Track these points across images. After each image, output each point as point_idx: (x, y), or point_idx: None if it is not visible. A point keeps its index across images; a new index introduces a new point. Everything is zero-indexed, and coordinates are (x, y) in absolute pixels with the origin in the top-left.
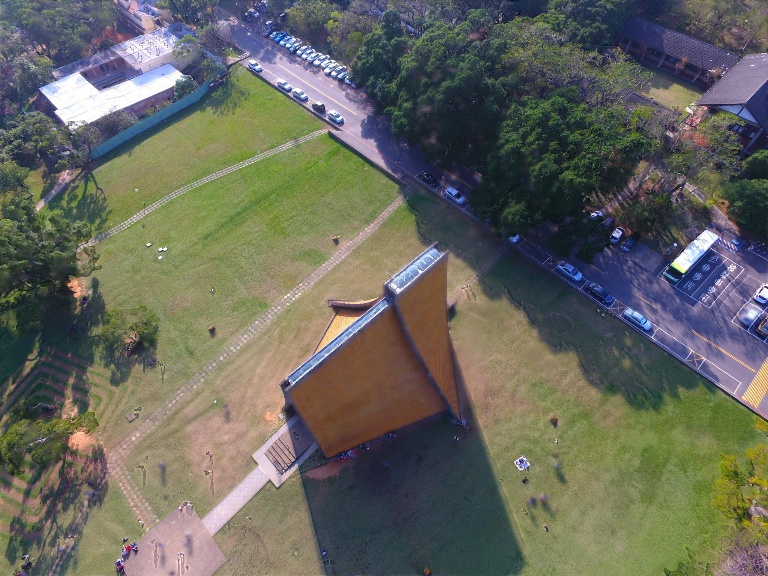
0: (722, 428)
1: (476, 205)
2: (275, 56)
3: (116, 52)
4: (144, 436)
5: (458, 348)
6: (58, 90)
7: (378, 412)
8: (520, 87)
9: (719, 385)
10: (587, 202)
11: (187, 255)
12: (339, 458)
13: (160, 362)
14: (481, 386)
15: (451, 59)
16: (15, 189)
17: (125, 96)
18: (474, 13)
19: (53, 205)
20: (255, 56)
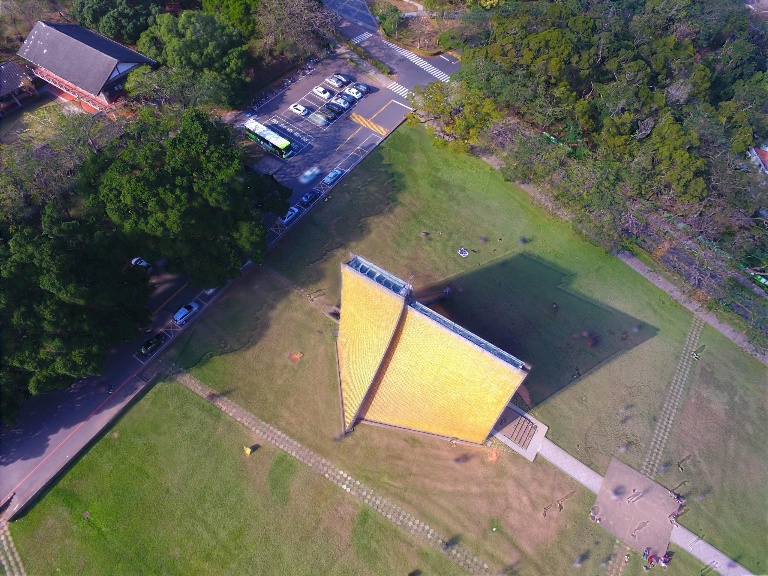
0: (407, 148)
1: (218, 280)
2: None
3: None
4: None
5: None
6: None
7: None
8: None
9: (377, 144)
10: None
11: None
12: None
13: None
14: None
15: (1, 269)
16: None
17: None
18: None
19: None
20: None
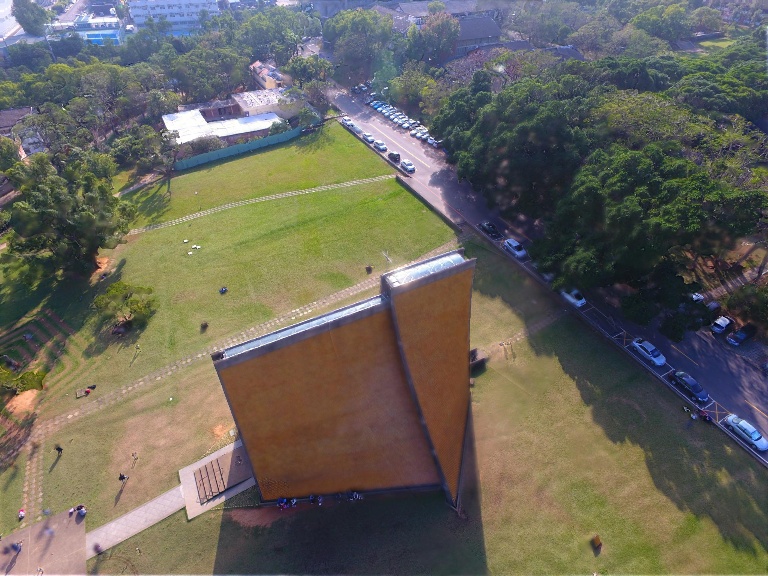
0: None
1: (536, 255)
2: (369, 118)
3: (234, 98)
4: (82, 417)
5: (477, 411)
6: (176, 119)
7: (344, 454)
8: (609, 143)
9: None
10: (681, 267)
11: (216, 255)
12: (278, 504)
13: (138, 346)
14: (496, 466)
15: (532, 103)
16: (100, 179)
17: (226, 129)
18: (568, 76)
19: (125, 198)
20: (351, 116)
